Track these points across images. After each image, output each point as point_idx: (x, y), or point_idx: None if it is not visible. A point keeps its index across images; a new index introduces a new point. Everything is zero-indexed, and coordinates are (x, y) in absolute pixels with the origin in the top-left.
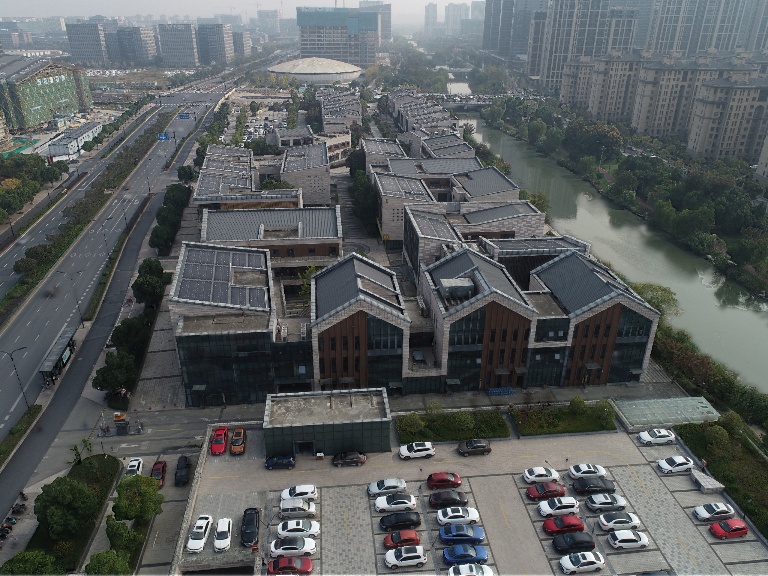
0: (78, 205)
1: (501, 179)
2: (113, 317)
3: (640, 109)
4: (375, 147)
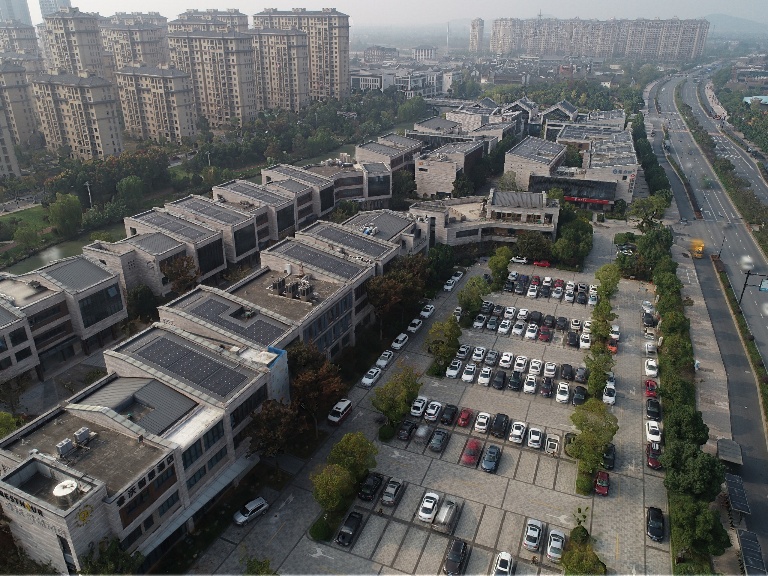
0: (739, 179)
1: (429, 121)
2: (658, 157)
3: (2, 148)
4: (464, 147)
